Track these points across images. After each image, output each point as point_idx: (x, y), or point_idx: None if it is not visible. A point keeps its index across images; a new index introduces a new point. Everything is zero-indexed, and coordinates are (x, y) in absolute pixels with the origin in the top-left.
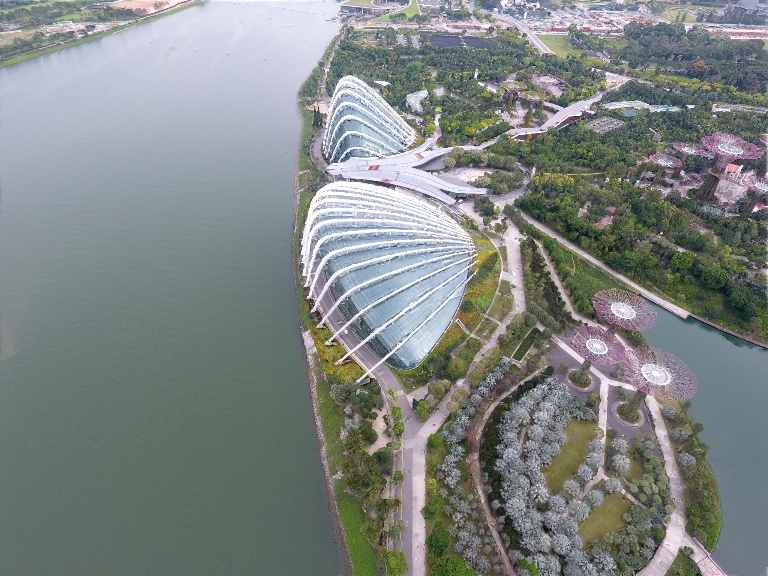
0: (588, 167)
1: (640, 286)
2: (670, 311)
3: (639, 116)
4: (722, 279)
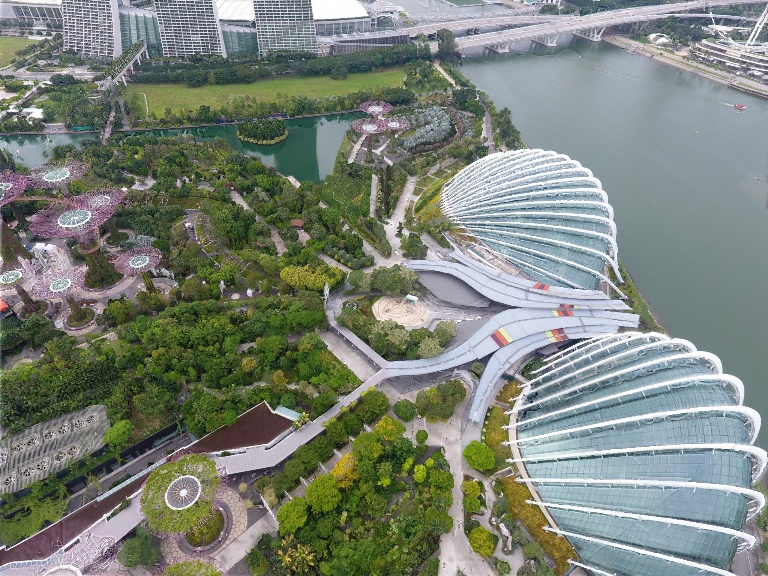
0: None
1: None
2: None
3: None
4: None
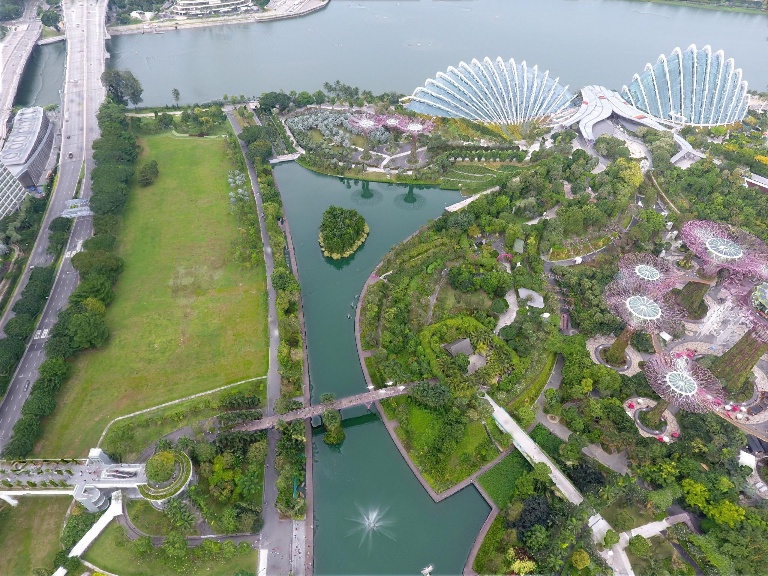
0: None
1: None
2: None
3: None
4: None
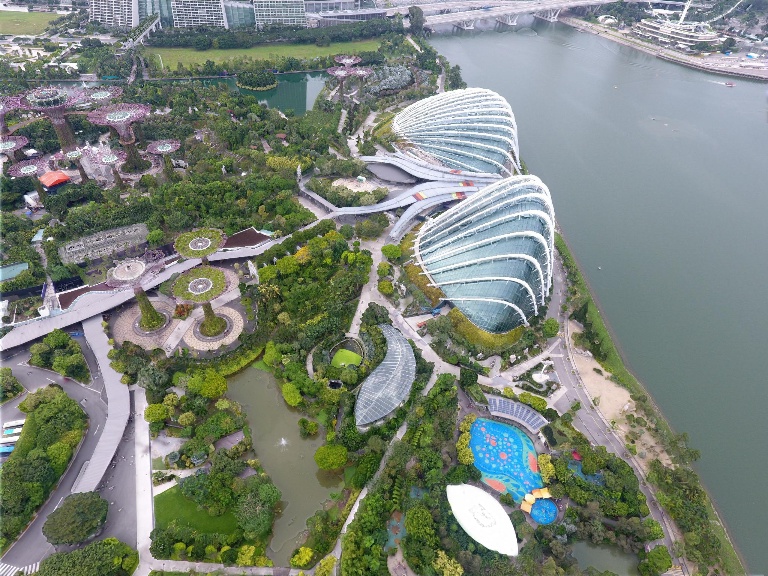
0: None
1: None
2: None
3: (7, 261)
4: None
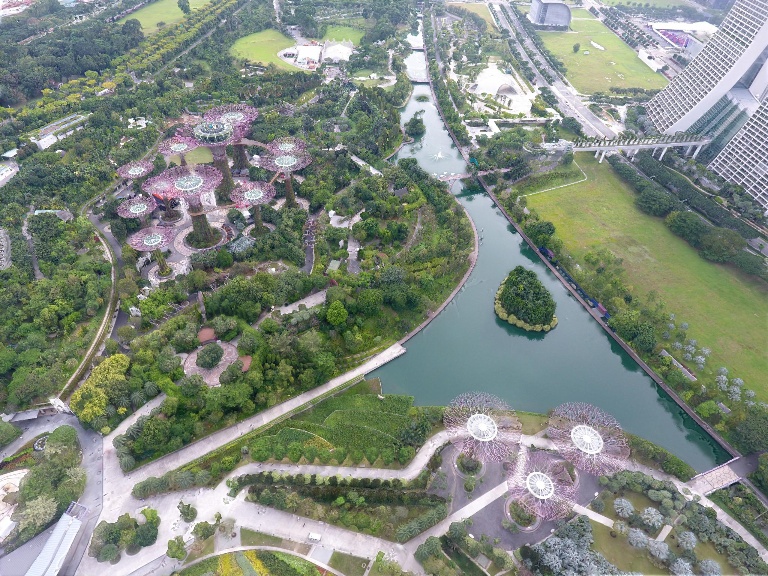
0: (85, 318)
1: (352, 370)
2: (393, 359)
3: None
4: (381, 298)
